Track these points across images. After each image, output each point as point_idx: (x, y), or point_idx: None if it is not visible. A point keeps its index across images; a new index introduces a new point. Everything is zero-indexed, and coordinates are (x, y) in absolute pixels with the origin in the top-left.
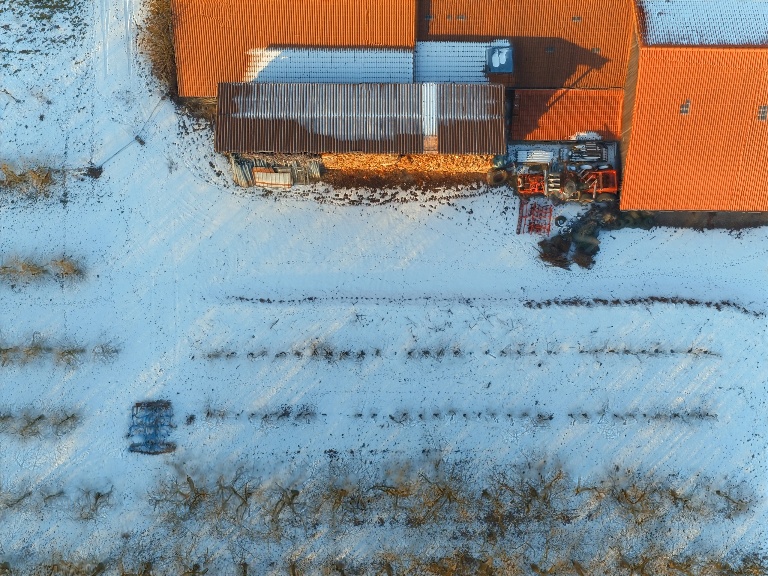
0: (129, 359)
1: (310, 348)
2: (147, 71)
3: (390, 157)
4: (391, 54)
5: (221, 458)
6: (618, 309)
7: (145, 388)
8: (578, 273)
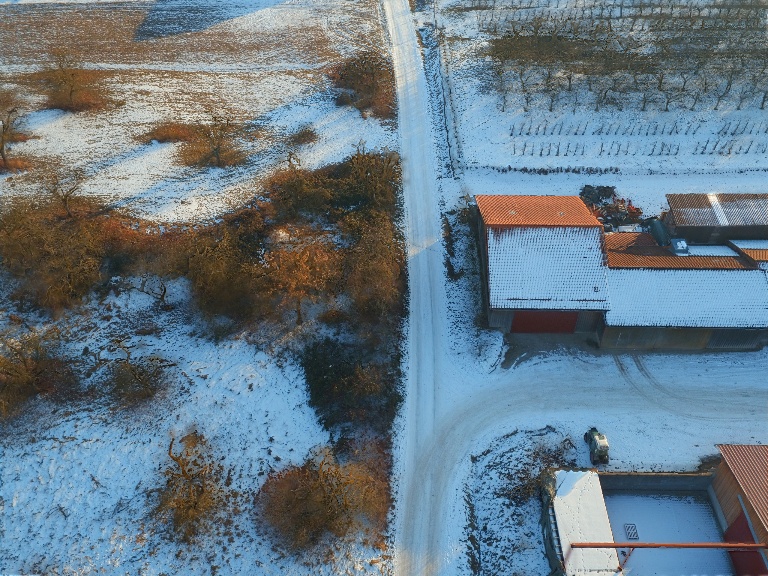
0: None
1: None
2: None
3: None
4: None
5: (759, 119)
6: None
7: None
8: None
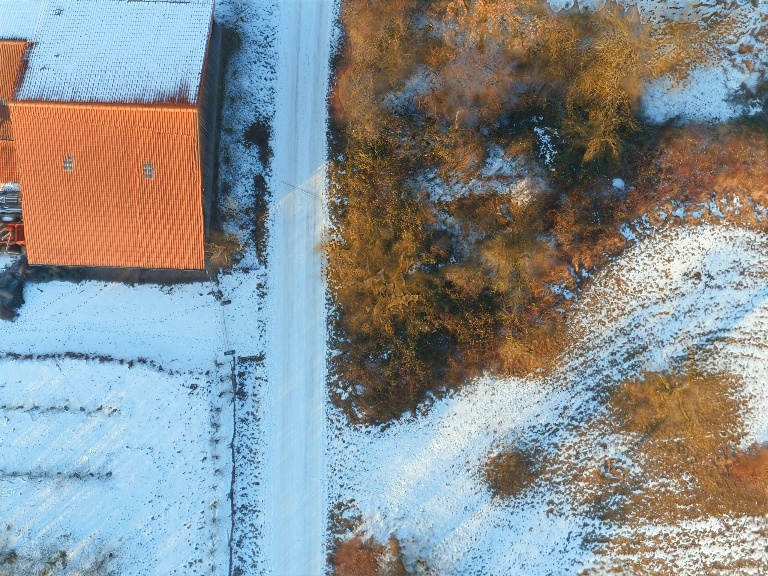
0: None
1: None
2: None
3: None
4: None
5: None
6: (27, 364)
7: None
8: (1, 326)
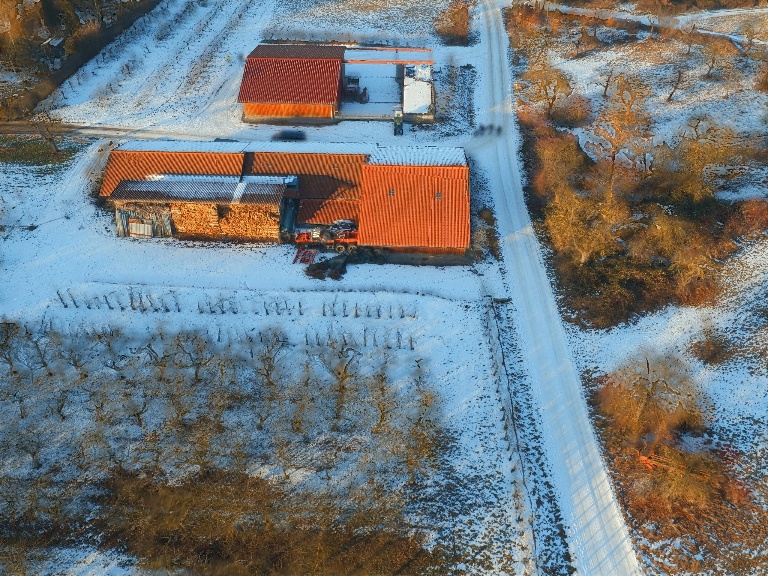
0: (3, 307)
1: (128, 290)
2: (87, 194)
3: (212, 211)
4: (227, 178)
5: None
6: (353, 293)
7: (5, 320)
8: (331, 282)
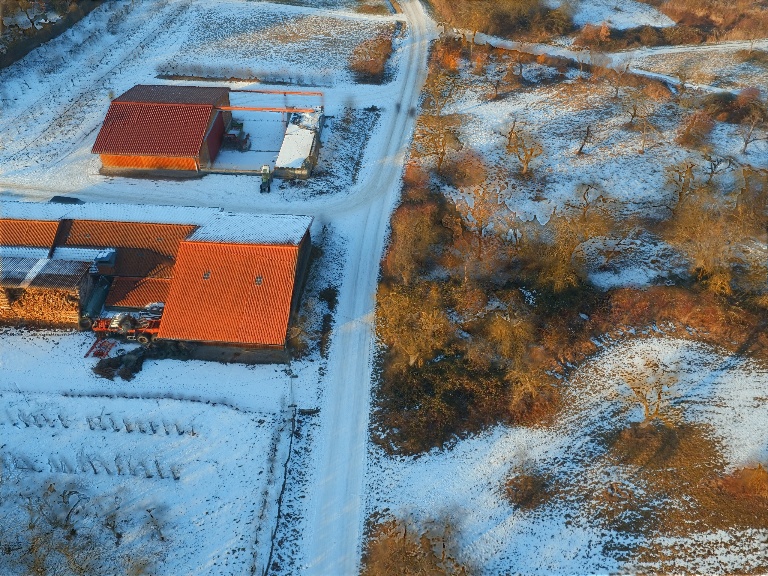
0: None
1: None
2: None
3: None
4: (36, 251)
5: None
6: (134, 401)
7: None
8: (119, 383)
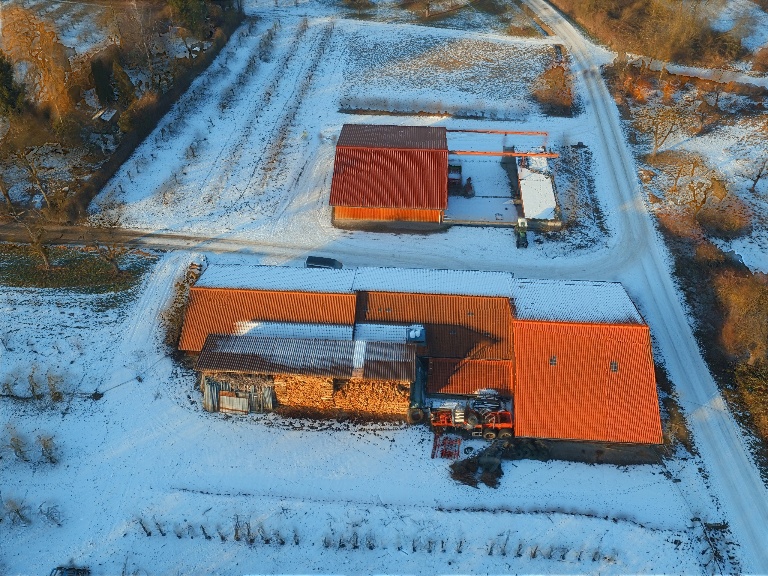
0: (67, 533)
1: (233, 520)
2: (160, 341)
3: (327, 384)
4: (337, 329)
5: None
6: (522, 517)
7: (71, 558)
8: (486, 491)
